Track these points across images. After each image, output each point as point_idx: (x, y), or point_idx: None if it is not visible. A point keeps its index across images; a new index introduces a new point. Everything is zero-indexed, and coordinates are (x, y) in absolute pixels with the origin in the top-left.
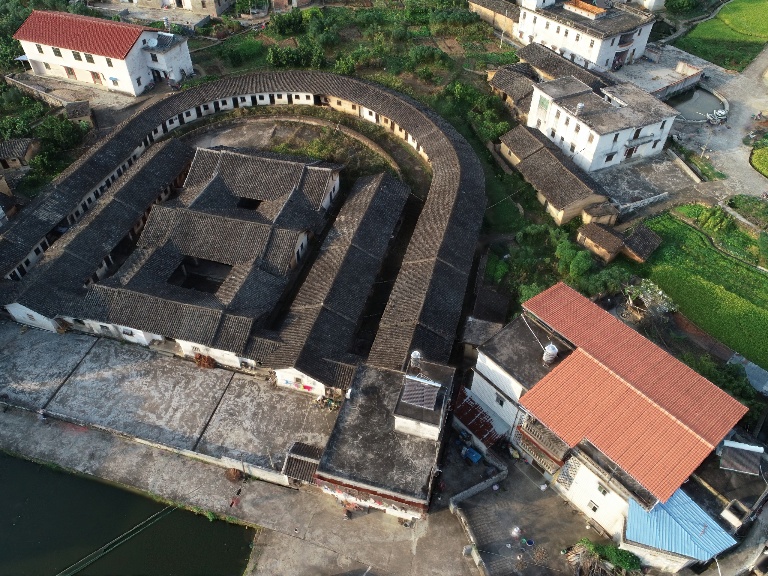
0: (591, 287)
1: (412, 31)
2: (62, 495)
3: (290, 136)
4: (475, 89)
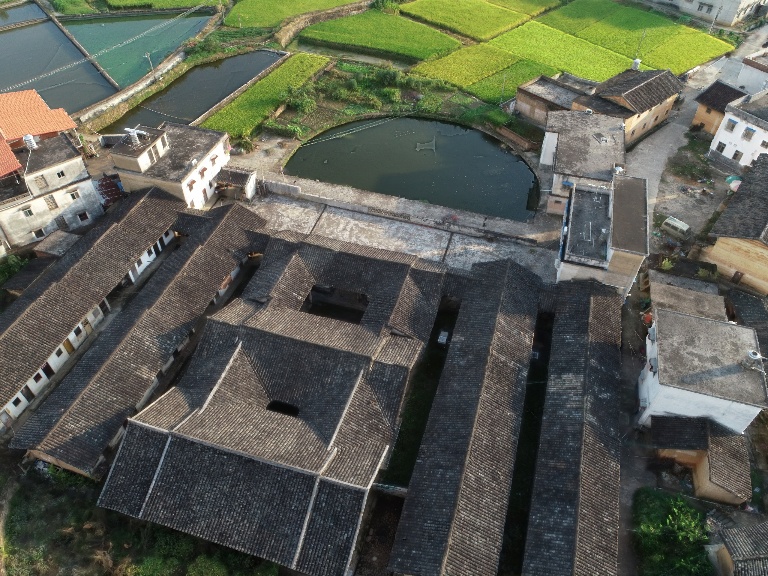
0: None
1: None
2: (410, 191)
3: None
4: None
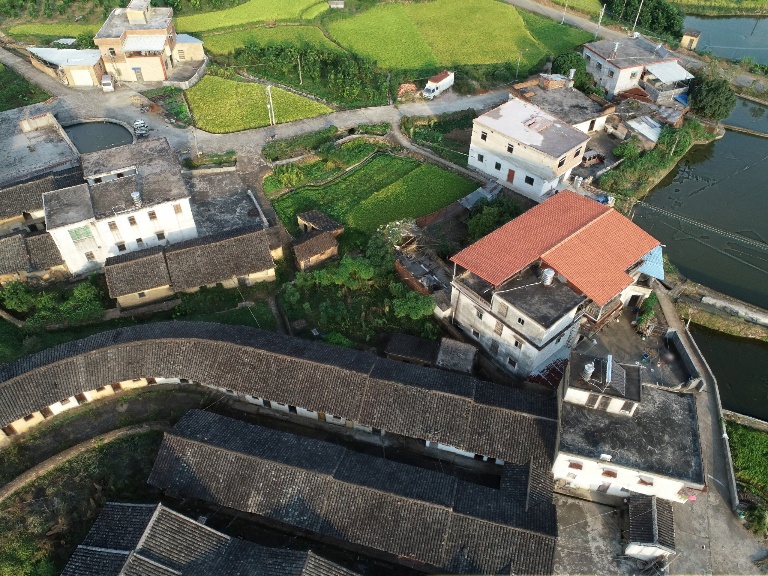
0: (390, 265)
1: None
2: None
3: None
4: None
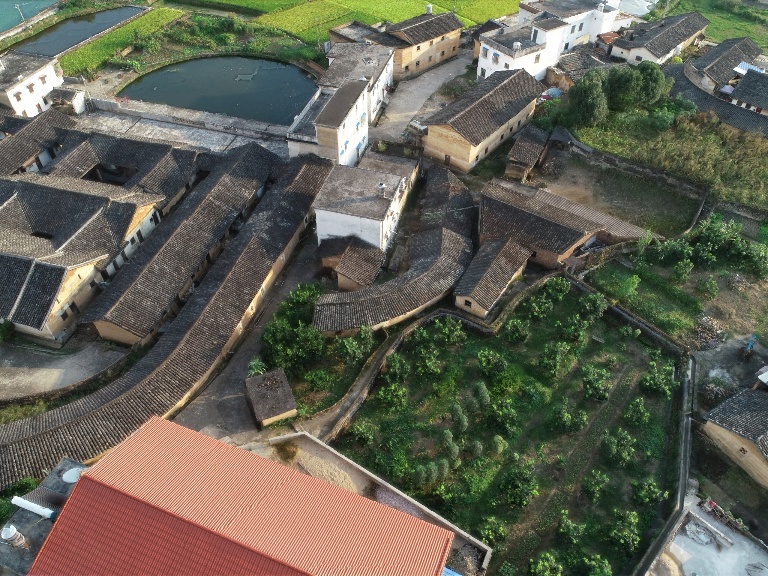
0: None
1: None
2: (216, 108)
3: None
4: None
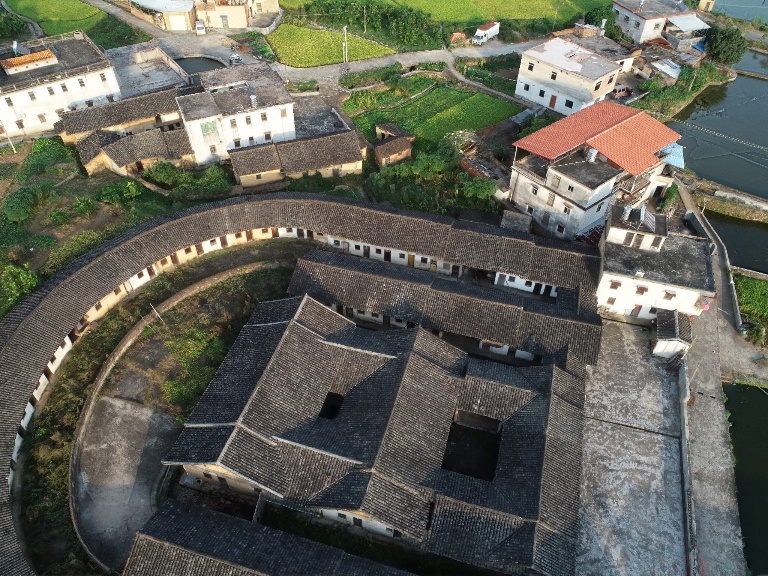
0: (458, 160)
1: None
2: None
3: (149, 375)
4: None
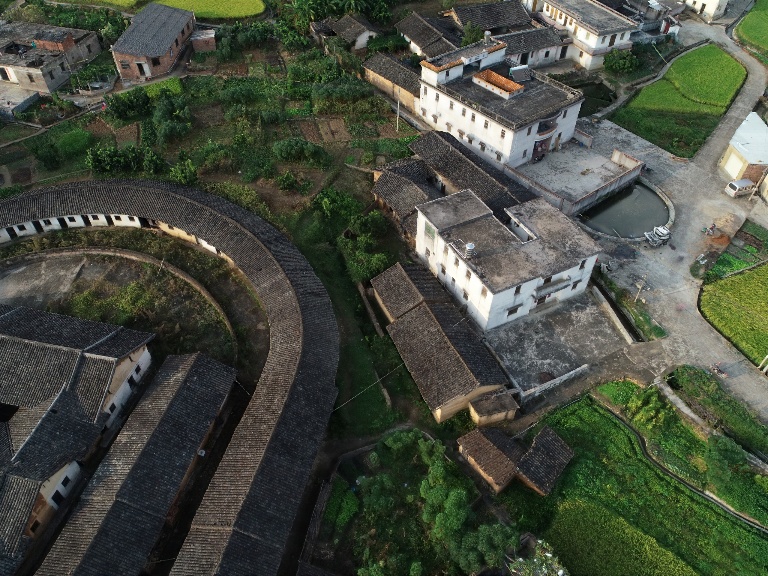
0: (461, 562)
1: (290, 109)
2: None
3: (98, 279)
4: (355, 196)
